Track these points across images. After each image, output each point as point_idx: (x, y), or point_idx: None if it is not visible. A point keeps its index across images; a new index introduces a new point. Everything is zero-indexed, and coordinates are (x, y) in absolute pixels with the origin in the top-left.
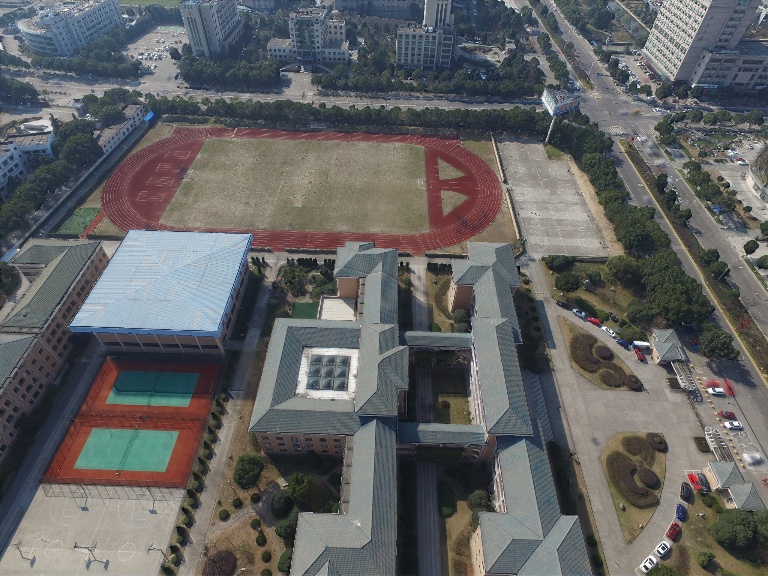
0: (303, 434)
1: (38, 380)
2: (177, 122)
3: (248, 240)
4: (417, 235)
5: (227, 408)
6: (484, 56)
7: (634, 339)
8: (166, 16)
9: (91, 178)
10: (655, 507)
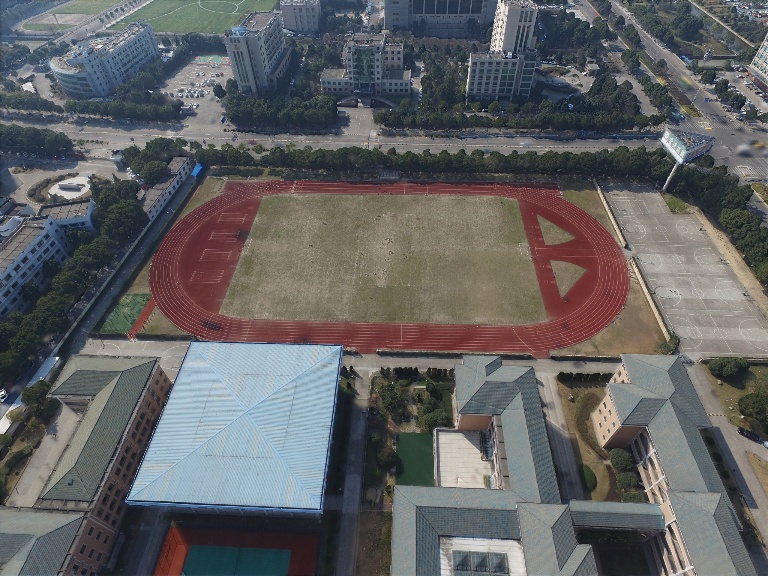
0: None
1: (88, 570)
2: (228, 175)
3: (339, 355)
4: (534, 327)
5: None
6: (562, 79)
7: None
8: (205, 45)
9: (136, 253)
10: None
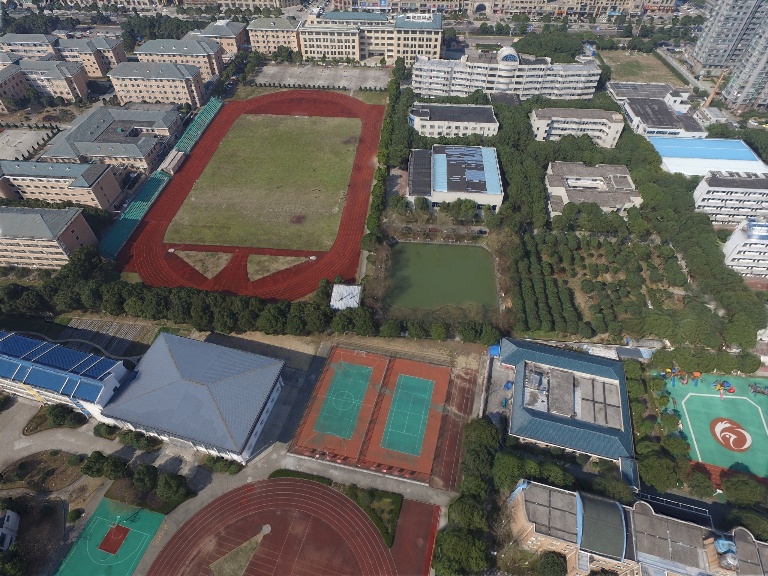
0: None
1: None
2: None
3: None
4: None
5: None
6: None
7: None
8: None
9: None
10: None
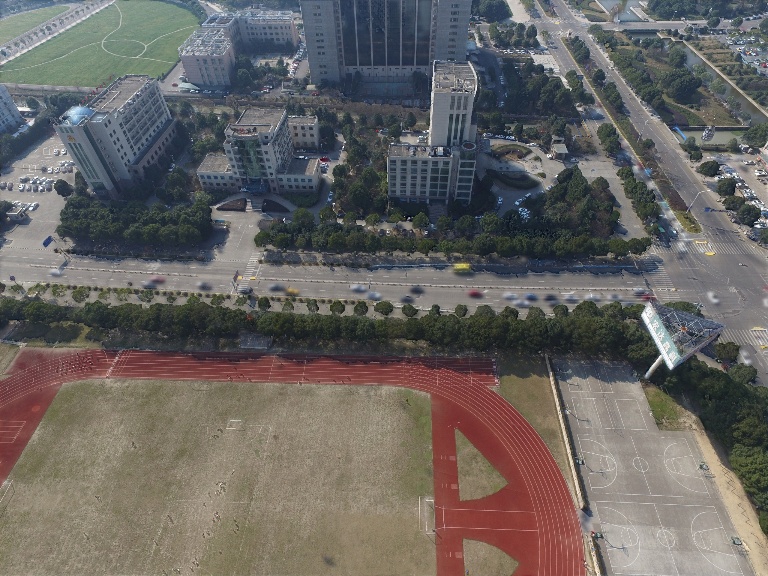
0: None
1: None
2: (28, 338)
3: None
4: None
5: None
6: (520, 165)
7: None
8: None
9: None
10: None
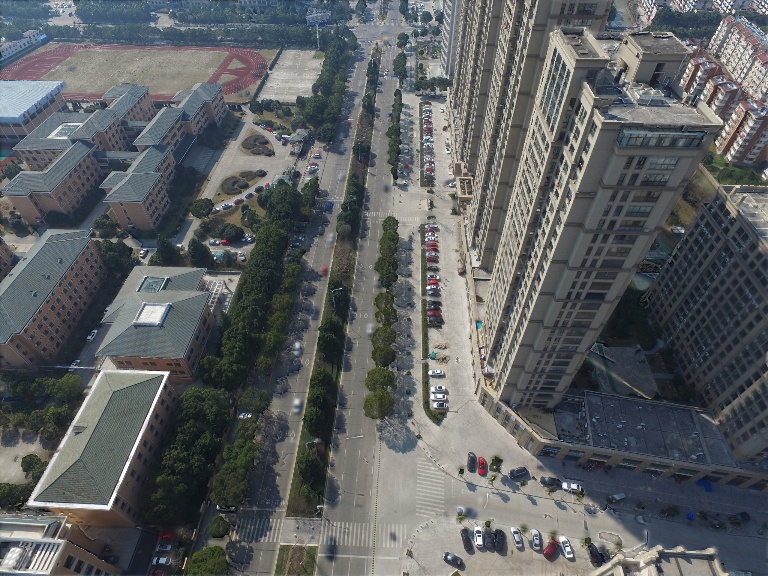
0: (44, 153)
1: None
2: (63, 42)
3: (60, 84)
4: None
5: (24, 162)
6: None
7: (283, 134)
8: None
9: None
10: (237, 194)
